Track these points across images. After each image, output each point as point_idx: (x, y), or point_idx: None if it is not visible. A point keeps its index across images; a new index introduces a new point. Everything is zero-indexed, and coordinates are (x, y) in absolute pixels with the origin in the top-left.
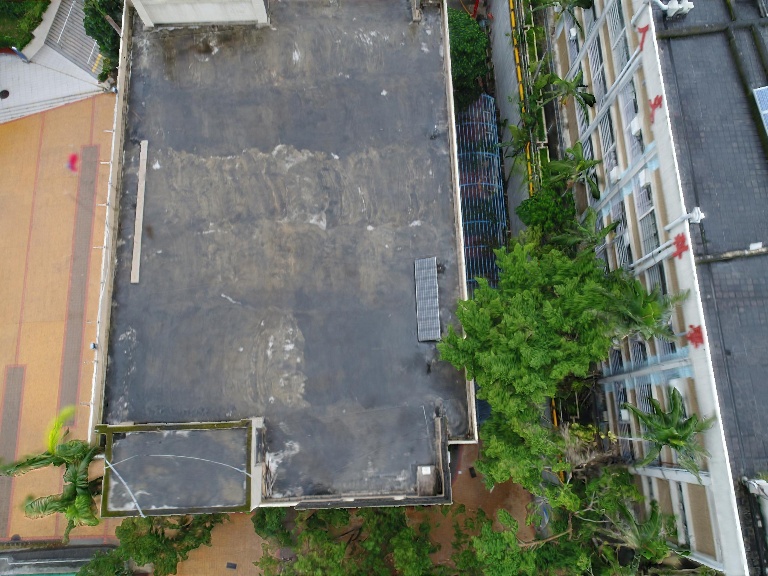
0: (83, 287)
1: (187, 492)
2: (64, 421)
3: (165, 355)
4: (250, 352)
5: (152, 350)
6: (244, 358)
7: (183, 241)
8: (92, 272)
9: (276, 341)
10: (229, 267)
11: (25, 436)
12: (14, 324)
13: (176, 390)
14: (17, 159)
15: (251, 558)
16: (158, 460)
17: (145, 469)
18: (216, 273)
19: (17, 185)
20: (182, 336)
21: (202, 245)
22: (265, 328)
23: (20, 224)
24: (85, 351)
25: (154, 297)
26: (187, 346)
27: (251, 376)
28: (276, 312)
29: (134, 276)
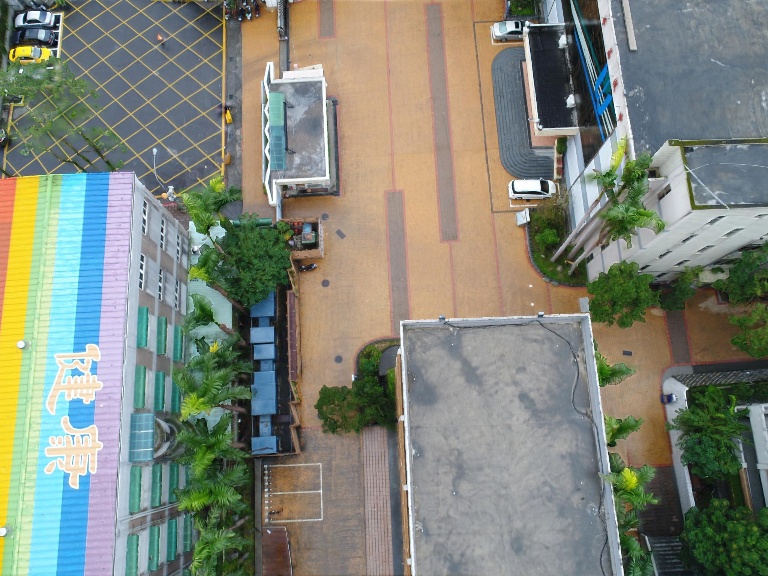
0: (446, 123)
1: (758, 192)
2: (448, 236)
3: (673, 107)
4: (747, 104)
5: (660, 103)
6: (743, 109)
7: (667, 18)
8: (452, 110)
9: (767, 95)
10: (712, 38)
11: (413, 250)
12: (387, 156)
13: (689, 134)
14: (366, 16)
15: (645, 346)
16: (727, 168)
17: (718, 174)
18: (702, 42)
19: (369, 38)
20: (684, 92)
21: (684, 21)
22: (756, 85)
23: (378, 71)
24: (457, 177)
25: (652, 62)
26: (690, 100)
27: (753, 123)
28: (763, 73)
29: (632, 44)
